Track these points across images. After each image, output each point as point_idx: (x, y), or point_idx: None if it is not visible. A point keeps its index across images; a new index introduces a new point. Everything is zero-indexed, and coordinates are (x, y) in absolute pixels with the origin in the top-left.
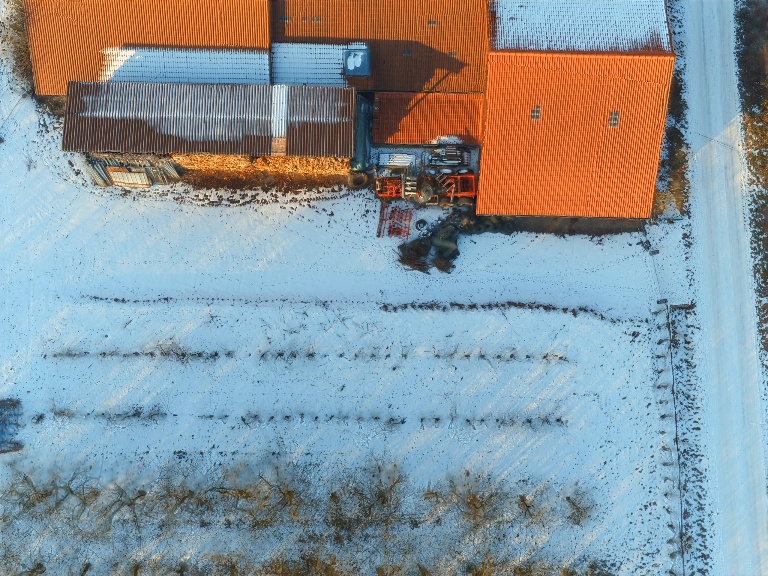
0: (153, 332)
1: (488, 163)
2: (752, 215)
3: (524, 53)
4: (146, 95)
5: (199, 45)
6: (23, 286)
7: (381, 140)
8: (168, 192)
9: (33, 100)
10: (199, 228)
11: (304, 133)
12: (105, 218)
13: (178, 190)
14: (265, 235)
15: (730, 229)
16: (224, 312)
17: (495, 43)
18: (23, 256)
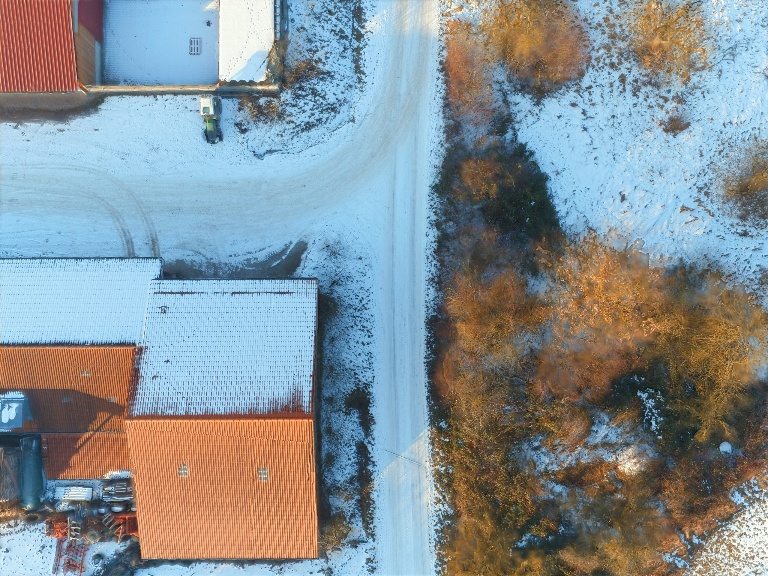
0: None
1: (143, 515)
2: (437, 536)
3: (160, 420)
4: None
5: None
6: None
7: (53, 476)
8: None
9: None
10: None
11: None
12: None
13: None
14: None
15: (415, 551)
16: None
17: (133, 408)
18: None
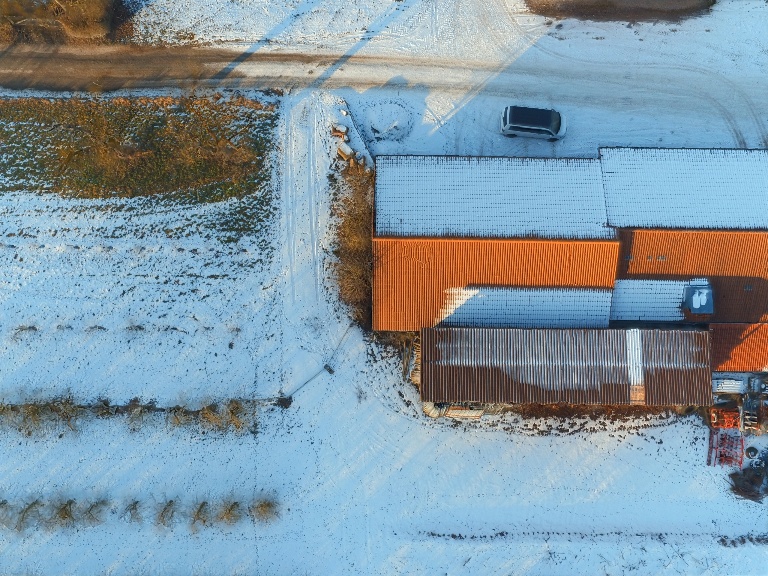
0: (492, 570)
1: None
2: None
3: None
4: (500, 341)
5: (544, 285)
6: (359, 522)
7: None
8: (498, 422)
9: (360, 329)
10: (530, 459)
11: (662, 380)
12: (437, 450)
13: (508, 420)
14: (595, 465)
15: None
16: (562, 548)
17: None
18: (358, 491)
